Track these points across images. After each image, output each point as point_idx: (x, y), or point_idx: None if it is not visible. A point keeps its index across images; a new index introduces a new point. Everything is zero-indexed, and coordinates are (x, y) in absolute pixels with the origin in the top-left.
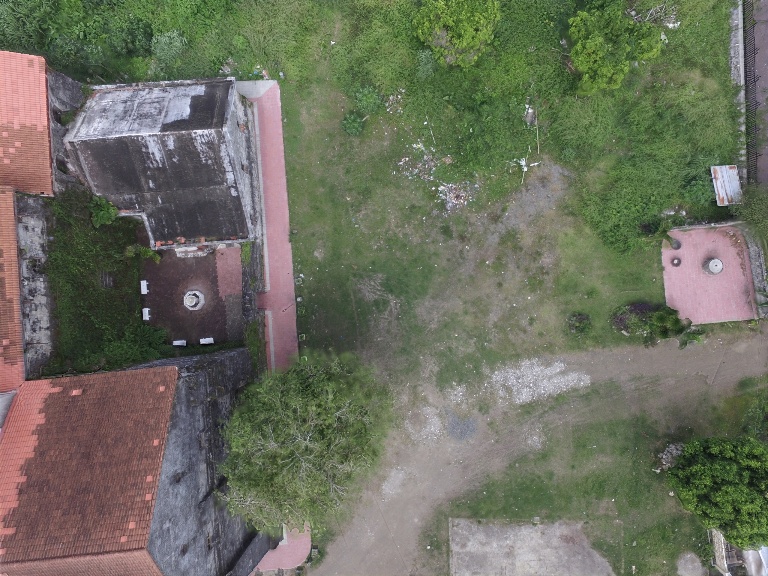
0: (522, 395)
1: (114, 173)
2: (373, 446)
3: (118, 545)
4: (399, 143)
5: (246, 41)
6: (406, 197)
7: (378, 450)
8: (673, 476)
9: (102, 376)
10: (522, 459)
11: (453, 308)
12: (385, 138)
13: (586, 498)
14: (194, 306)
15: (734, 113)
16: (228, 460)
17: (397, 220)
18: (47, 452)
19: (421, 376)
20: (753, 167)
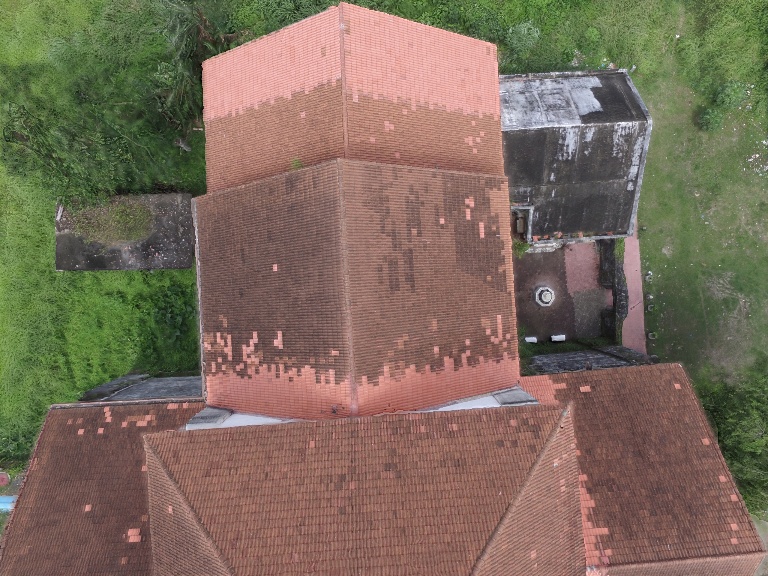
0: None
1: (519, 165)
2: None
3: (732, 547)
4: (748, 139)
5: (598, 33)
6: (756, 194)
7: None
8: None
9: (603, 373)
10: None
11: None
12: (734, 134)
13: None
14: (547, 302)
15: None
16: (749, 460)
17: (747, 218)
18: (593, 450)
19: None
20: None
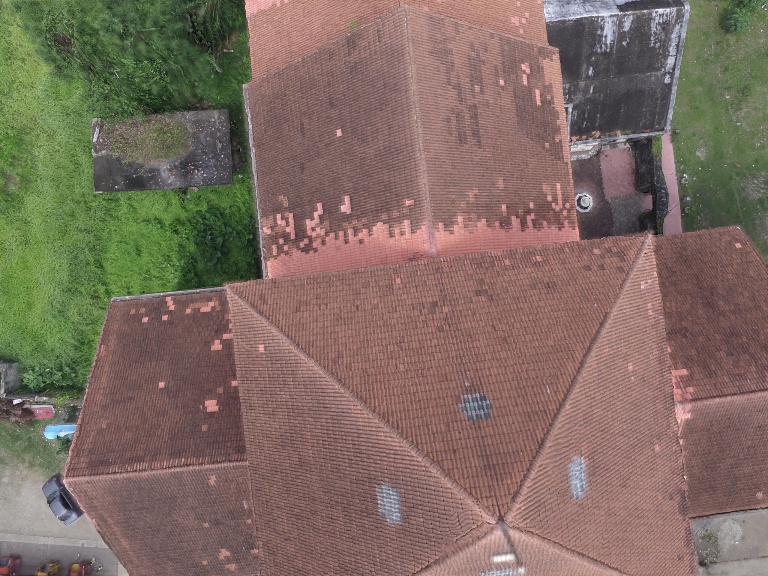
0: None
1: None
2: None
3: None
4: None
5: None
6: None
7: None
8: None
9: (663, 238)
10: None
11: None
12: (761, 35)
13: None
14: (586, 208)
15: None
16: None
17: None
18: None
19: None
20: None
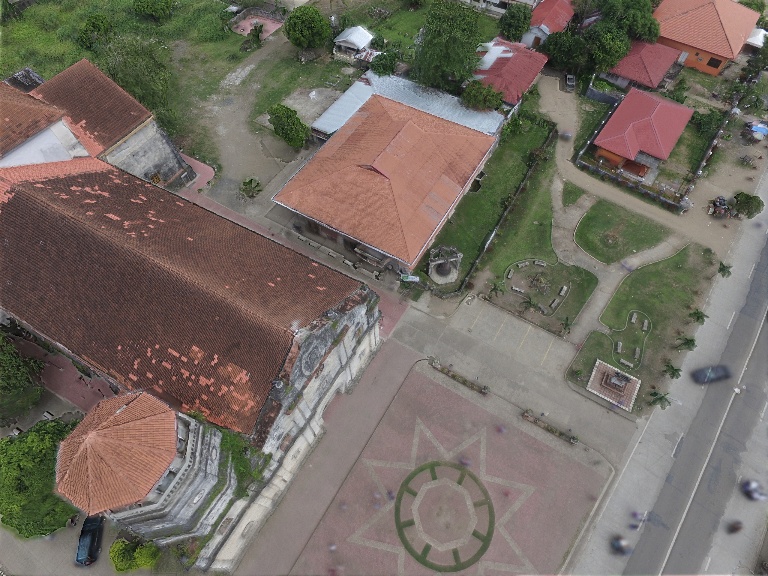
0: (236, 82)
1: None
2: (199, 129)
3: None
4: None
5: None
6: None
7: (203, 128)
8: (289, 41)
9: None
10: (258, 93)
11: (183, 84)
12: None
13: (292, 83)
14: None
15: (217, 3)
16: None
17: None
18: None
19: (194, 104)
20: (236, 4)
